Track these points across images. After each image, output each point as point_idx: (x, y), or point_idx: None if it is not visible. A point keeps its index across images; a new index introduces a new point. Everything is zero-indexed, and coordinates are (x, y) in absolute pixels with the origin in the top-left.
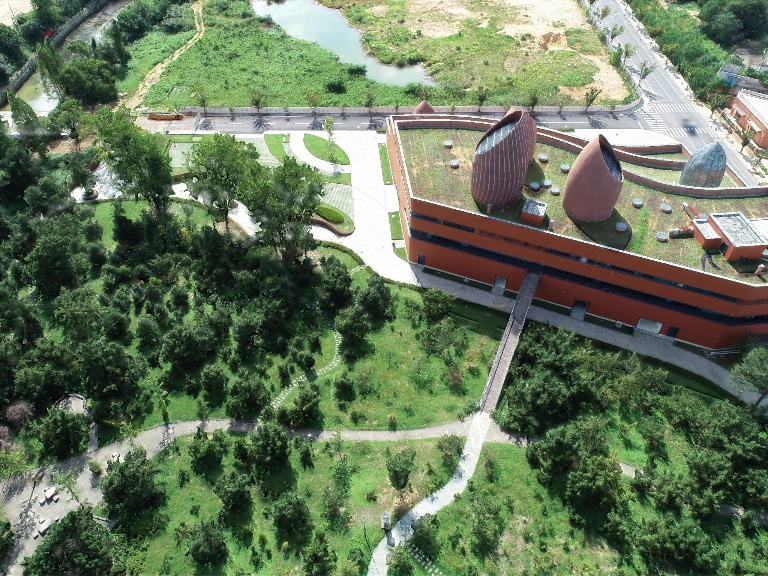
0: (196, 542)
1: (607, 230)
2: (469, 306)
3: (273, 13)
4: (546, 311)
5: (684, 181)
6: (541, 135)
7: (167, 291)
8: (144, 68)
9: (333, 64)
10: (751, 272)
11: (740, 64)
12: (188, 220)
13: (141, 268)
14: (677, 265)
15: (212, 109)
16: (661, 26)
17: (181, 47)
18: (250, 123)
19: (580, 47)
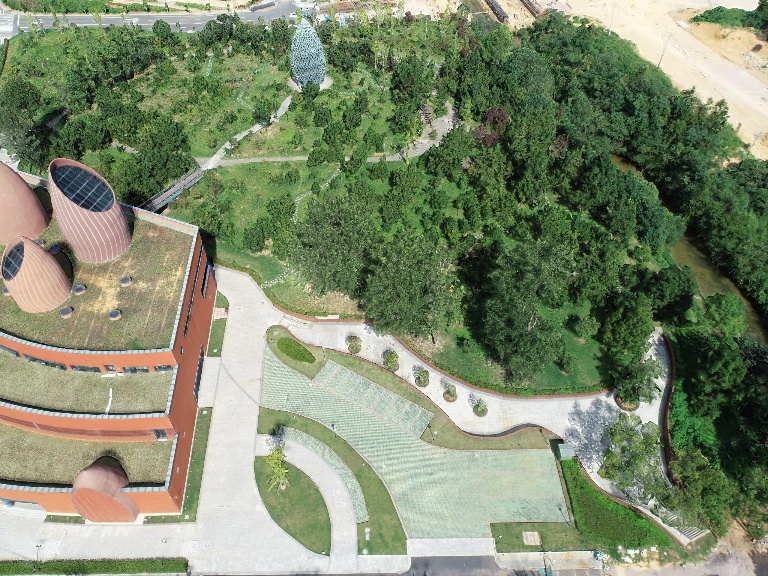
0: (363, 92)
1: None
2: None
3: None
4: None
5: None
6: None
7: None
8: None
9: None
10: None
11: None
12: None
13: (468, 234)
14: None
15: None
16: None
17: None
18: None
19: None
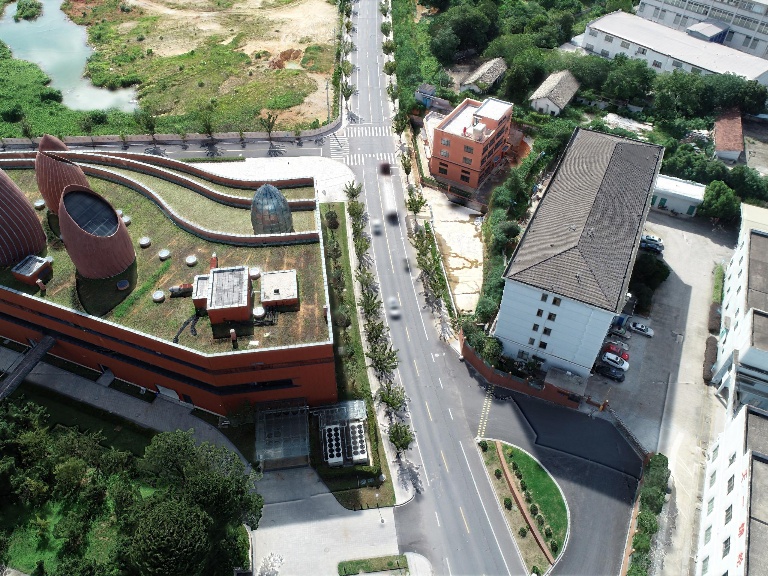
0: None
1: (106, 289)
2: None
3: (18, 31)
4: (73, 376)
5: (252, 225)
6: (117, 175)
7: None
8: None
9: (31, 89)
10: (228, 337)
11: (447, 83)
12: None
13: None
14: (139, 332)
15: None
16: None
17: None
18: None
19: (311, 65)
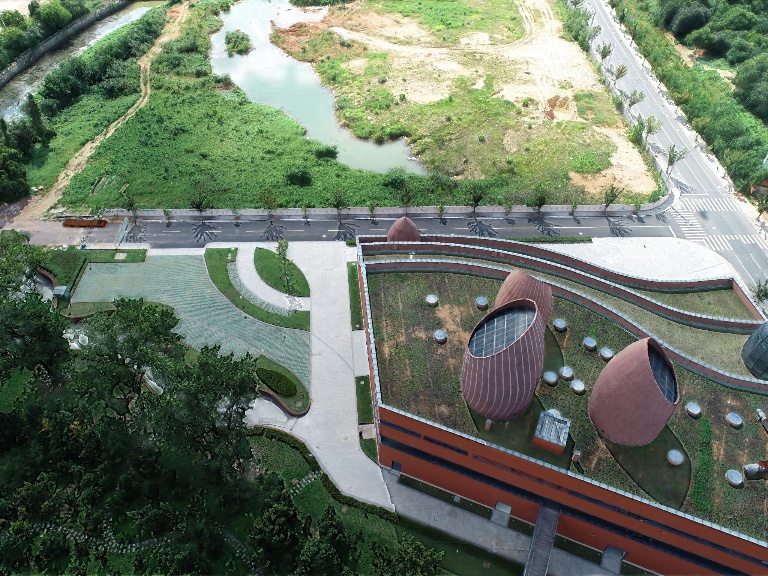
0: None
1: (656, 463)
2: (461, 549)
3: (235, 67)
4: (567, 556)
5: (750, 359)
6: (556, 286)
7: (41, 530)
8: (69, 149)
9: (298, 142)
10: None
11: None
12: (83, 406)
13: None
14: (766, 544)
15: (143, 212)
16: (688, 92)
17: (118, 118)
18: (190, 231)
19: (592, 116)
